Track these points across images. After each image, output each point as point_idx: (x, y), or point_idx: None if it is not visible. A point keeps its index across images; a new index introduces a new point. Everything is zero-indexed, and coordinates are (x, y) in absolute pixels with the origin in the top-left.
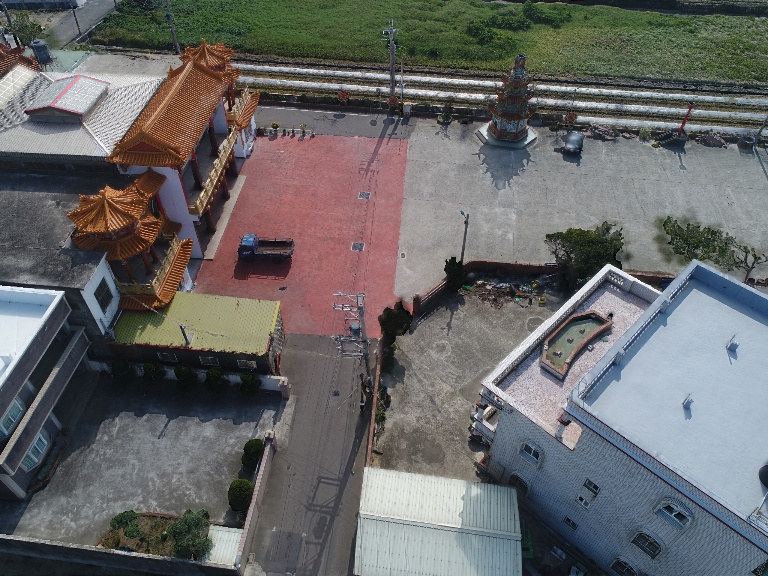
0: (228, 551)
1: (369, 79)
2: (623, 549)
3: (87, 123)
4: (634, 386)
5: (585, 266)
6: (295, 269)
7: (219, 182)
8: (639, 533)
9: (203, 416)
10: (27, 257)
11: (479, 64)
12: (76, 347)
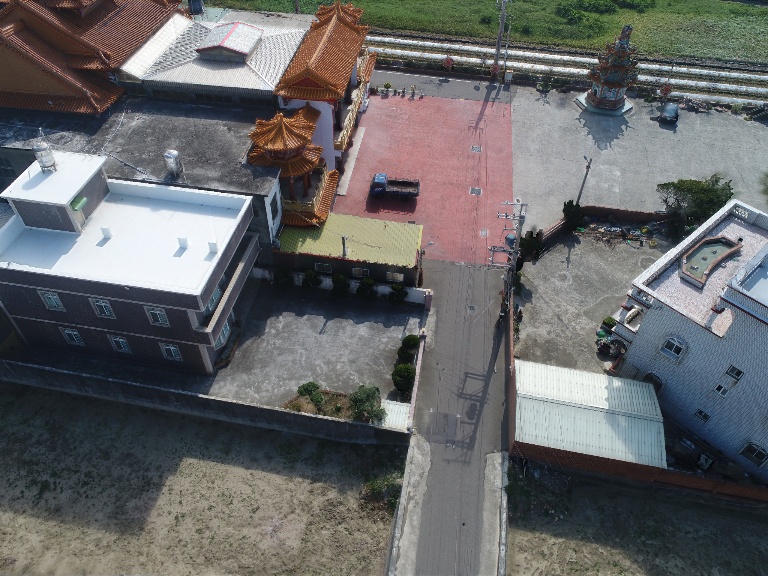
0: (400, 420)
1: (466, 51)
2: (757, 433)
3: (250, 62)
4: None
5: (699, 210)
6: (421, 207)
7: (352, 126)
8: None
9: (356, 319)
10: (213, 169)
11: (570, 42)
12: (253, 249)
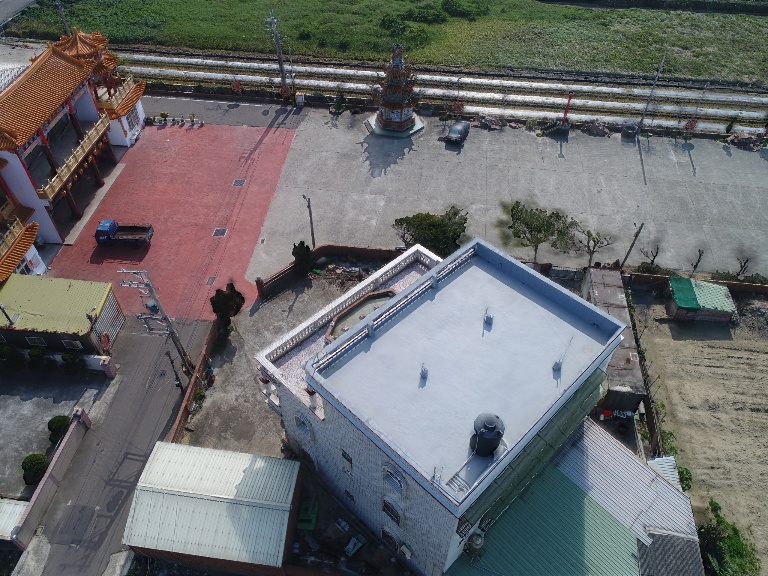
0: (9, 523)
1: (274, 70)
2: (384, 518)
3: None
4: (380, 357)
5: None
6: (152, 254)
7: (82, 168)
8: (383, 500)
9: (25, 395)
10: None
11: (386, 56)
12: None
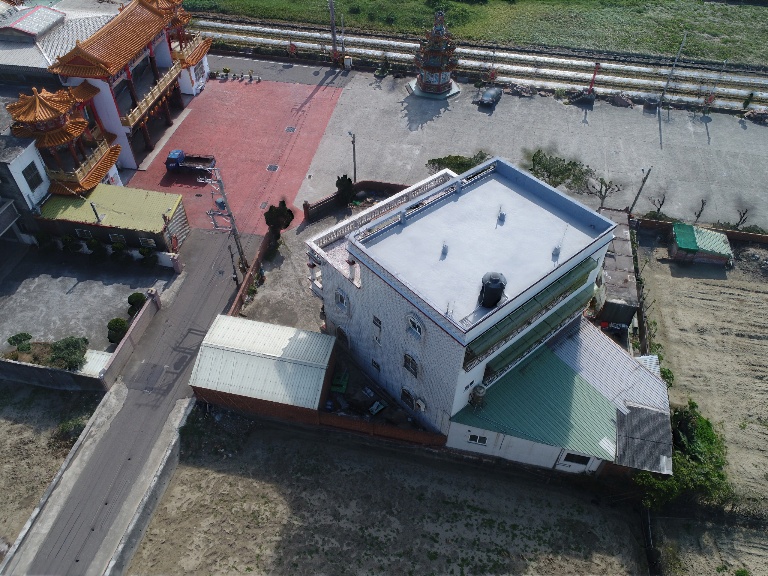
0: (97, 367)
1: (325, 39)
2: (404, 378)
3: (40, 43)
4: (409, 238)
5: None
6: None
7: (157, 106)
8: (404, 355)
9: (107, 281)
10: None
11: None
12: (5, 214)
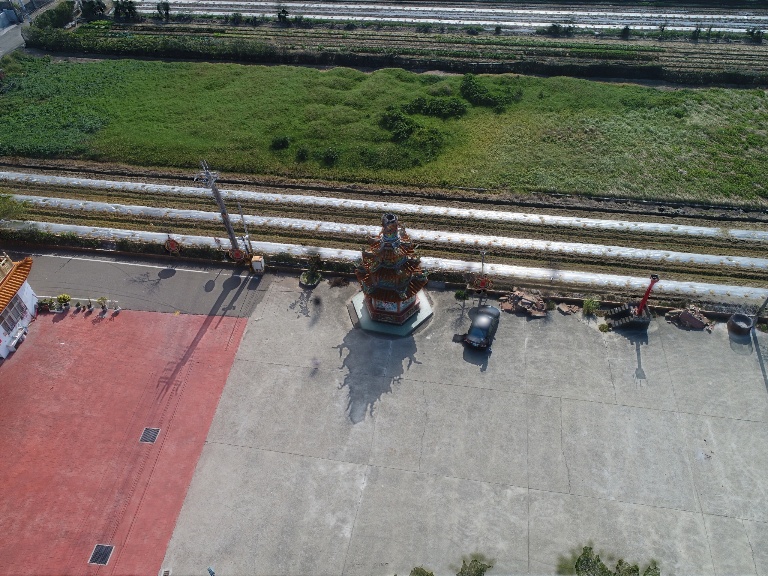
0: None
1: None
2: None
3: None
4: None
5: None
6: None
7: None
8: None
9: None
10: None
11: (385, 175)
12: None
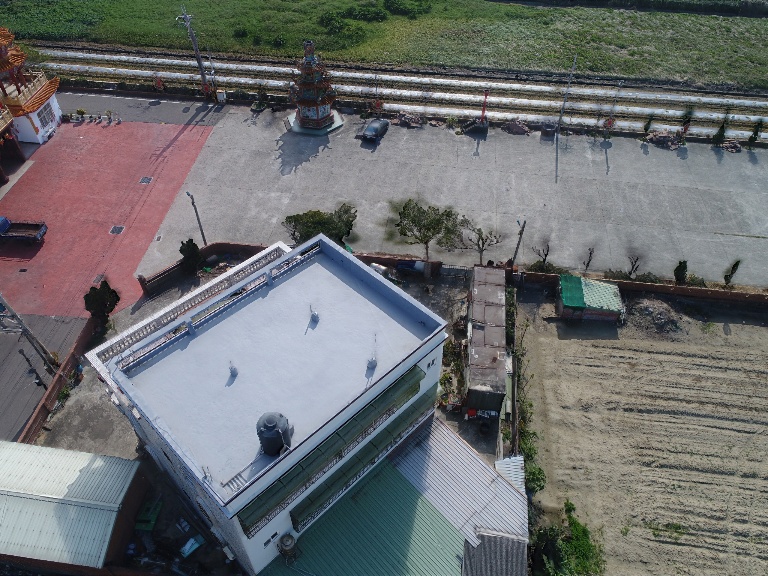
0: None
1: (205, 68)
2: None
3: None
4: (195, 355)
5: None
6: (44, 251)
7: None
8: (196, 501)
9: None
10: None
11: None
12: None
